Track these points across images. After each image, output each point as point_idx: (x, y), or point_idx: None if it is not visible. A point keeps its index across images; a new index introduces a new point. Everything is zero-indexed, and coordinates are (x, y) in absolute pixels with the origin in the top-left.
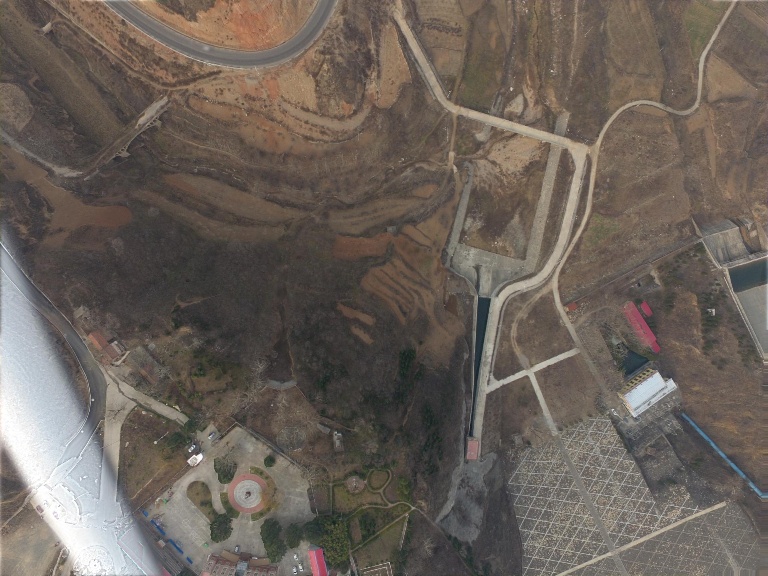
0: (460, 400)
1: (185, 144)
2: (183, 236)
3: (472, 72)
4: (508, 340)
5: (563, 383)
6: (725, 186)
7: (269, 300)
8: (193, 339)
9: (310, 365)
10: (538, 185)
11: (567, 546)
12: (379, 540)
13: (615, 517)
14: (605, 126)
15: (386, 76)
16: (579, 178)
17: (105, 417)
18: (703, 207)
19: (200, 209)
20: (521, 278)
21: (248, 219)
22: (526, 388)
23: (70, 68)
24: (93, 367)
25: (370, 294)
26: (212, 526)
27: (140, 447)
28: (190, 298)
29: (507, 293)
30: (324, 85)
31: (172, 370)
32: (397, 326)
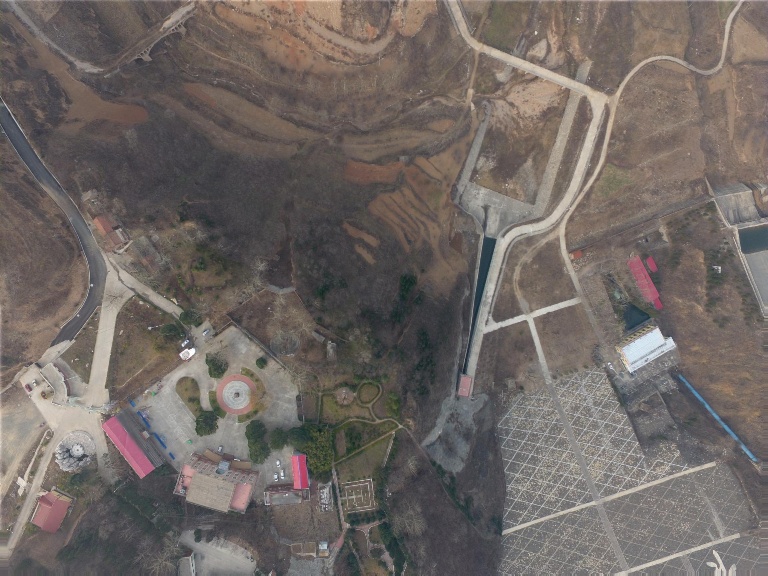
0: (457, 332)
1: (207, 55)
2: (197, 141)
3: (498, 12)
4: (510, 283)
5: (561, 332)
6: (742, 149)
7: (276, 211)
8: (197, 232)
9: (311, 272)
10: (554, 131)
11: (551, 492)
12: (363, 455)
13: (602, 467)
14: (626, 78)
15: (412, 5)
16: (596, 127)
17: (102, 303)
18: (718, 168)
19: (216, 119)
20: (529, 221)
21: (262, 135)
22: (524, 333)
23: None
24: (95, 253)
25: (377, 218)
26: (198, 418)
27: (134, 336)
28: (198, 199)
29: (513, 235)
30: (350, 3)
31: (173, 261)
32: (401, 252)
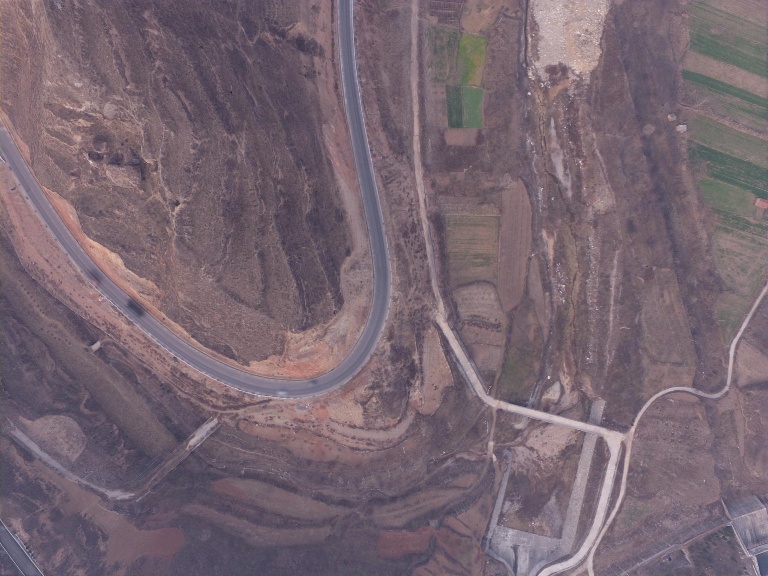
0: None
1: (232, 449)
2: (234, 554)
3: (511, 364)
4: None
5: None
6: (753, 467)
7: None
8: None
9: None
10: (574, 467)
11: None
12: None
13: None
14: (639, 413)
15: (429, 382)
16: (614, 464)
17: None
18: (732, 484)
19: (248, 515)
20: (558, 560)
21: (295, 519)
22: None
23: (119, 383)
24: None
25: None
26: None
27: None
28: None
29: (544, 575)
30: (372, 411)
31: None
32: None
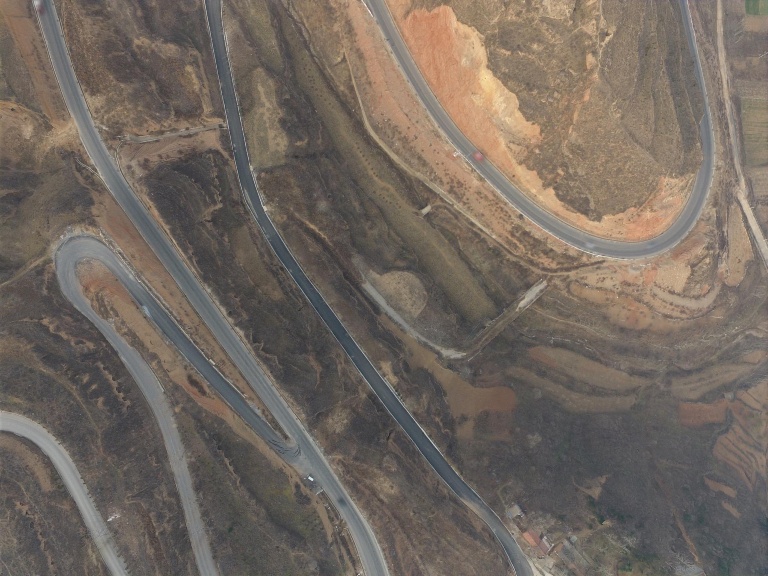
0: None
1: (545, 318)
2: (561, 414)
3: None
4: None
5: None
6: None
7: (647, 478)
8: (623, 536)
9: (716, 553)
10: None
11: None
12: None
13: None
14: None
15: (733, 255)
16: None
17: None
18: None
19: (562, 381)
20: None
21: (601, 388)
22: None
23: (444, 248)
24: (521, 560)
25: (724, 464)
26: None
27: None
28: (584, 481)
29: None
30: (699, 274)
31: None
32: (749, 494)
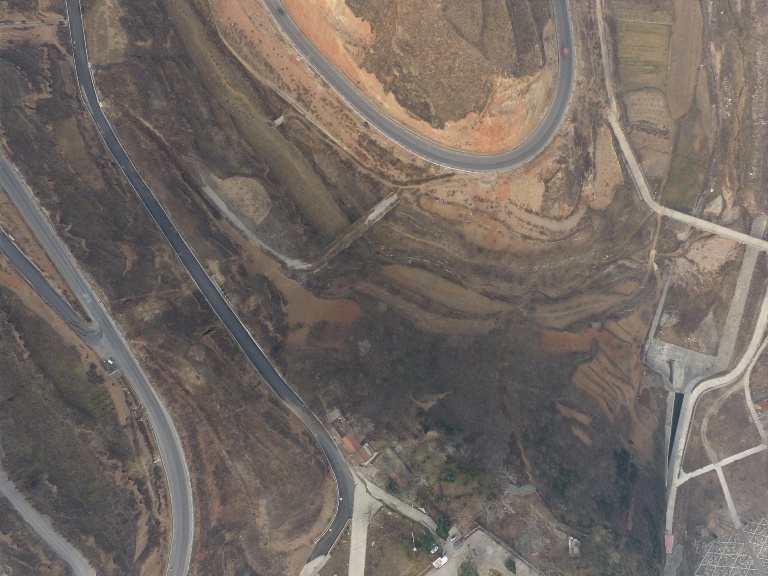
0: None
1: (402, 236)
2: (408, 331)
3: (676, 173)
4: (698, 434)
5: (748, 478)
6: None
7: (493, 398)
8: (446, 446)
9: (549, 472)
10: (732, 284)
11: None
12: None
13: None
14: None
15: (601, 178)
16: None
17: (352, 516)
18: None
19: (416, 301)
20: (715, 375)
21: (460, 311)
22: (713, 482)
23: (298, 160)
24: (342, 467)
25: (582, 392)
26: None
27: (387, 547)
28: (422, 396)
29: (701, 389)
30: (553, 191)
31: None
32: (608, 424)
